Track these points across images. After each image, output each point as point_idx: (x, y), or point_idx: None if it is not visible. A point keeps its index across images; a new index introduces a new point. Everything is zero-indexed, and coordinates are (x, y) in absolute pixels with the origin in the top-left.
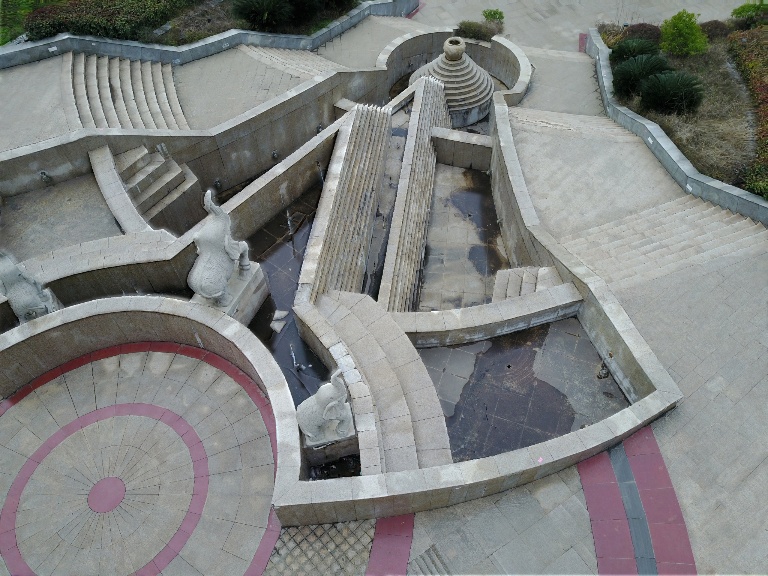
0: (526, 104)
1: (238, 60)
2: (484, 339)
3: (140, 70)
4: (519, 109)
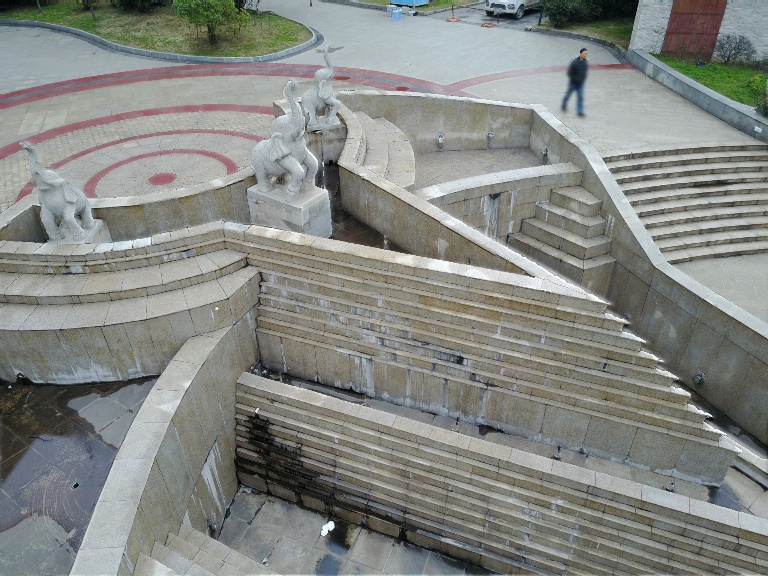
0: None
1: None
2: None
3: None
4: None
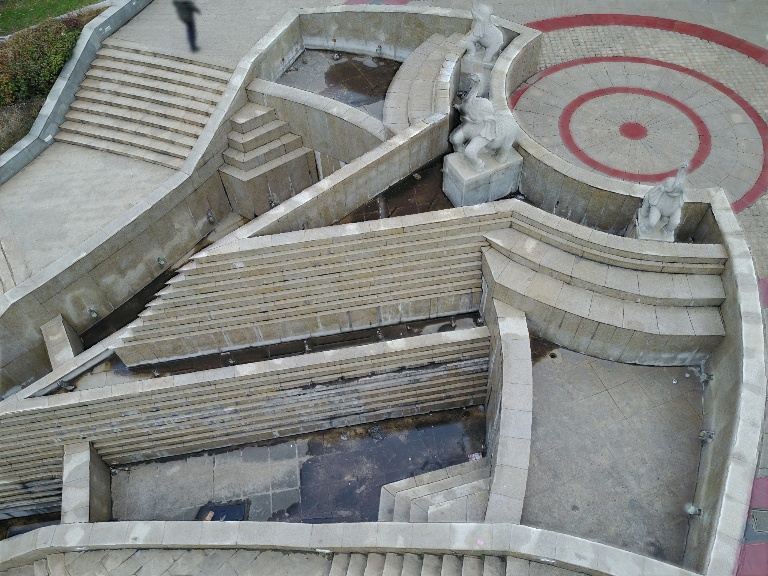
0: None
1: None
2: None
3: None
4: None
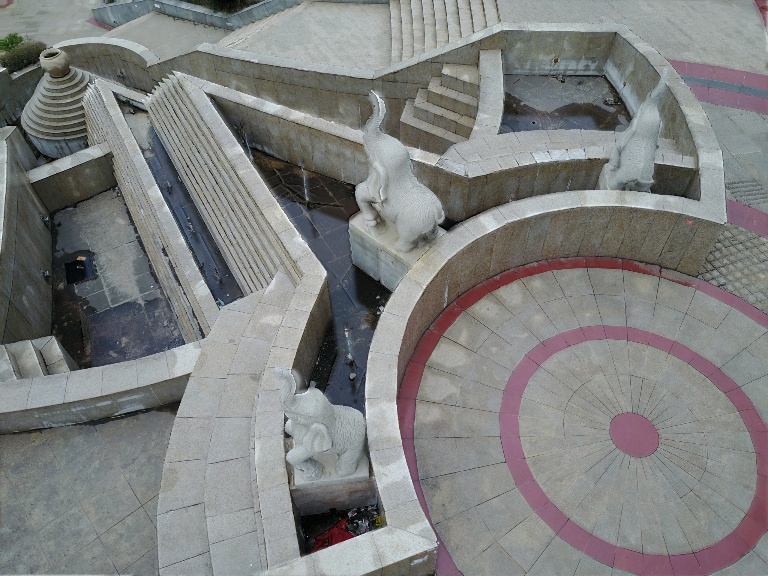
0: None
1: None
2: None
3: None
4: None
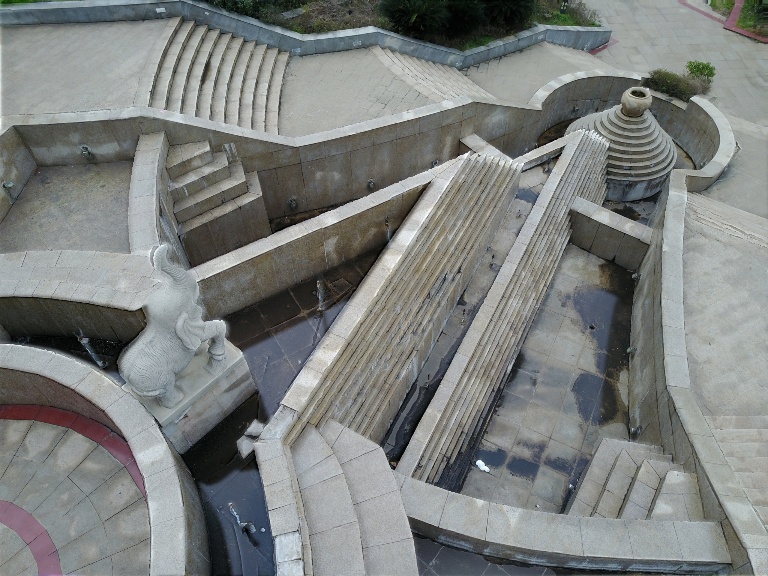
0: (714, 193)
1: (365, 63)
2: (545, 564)
3: (251, 52)
4: (703, 199)
